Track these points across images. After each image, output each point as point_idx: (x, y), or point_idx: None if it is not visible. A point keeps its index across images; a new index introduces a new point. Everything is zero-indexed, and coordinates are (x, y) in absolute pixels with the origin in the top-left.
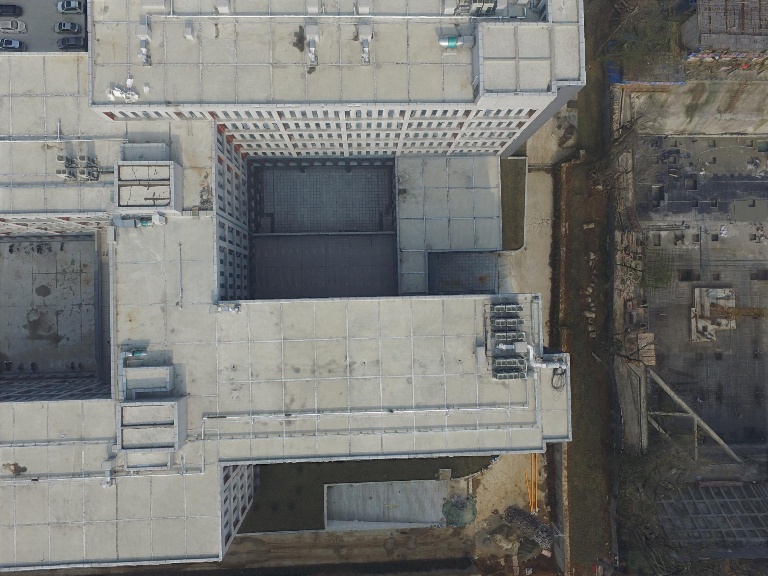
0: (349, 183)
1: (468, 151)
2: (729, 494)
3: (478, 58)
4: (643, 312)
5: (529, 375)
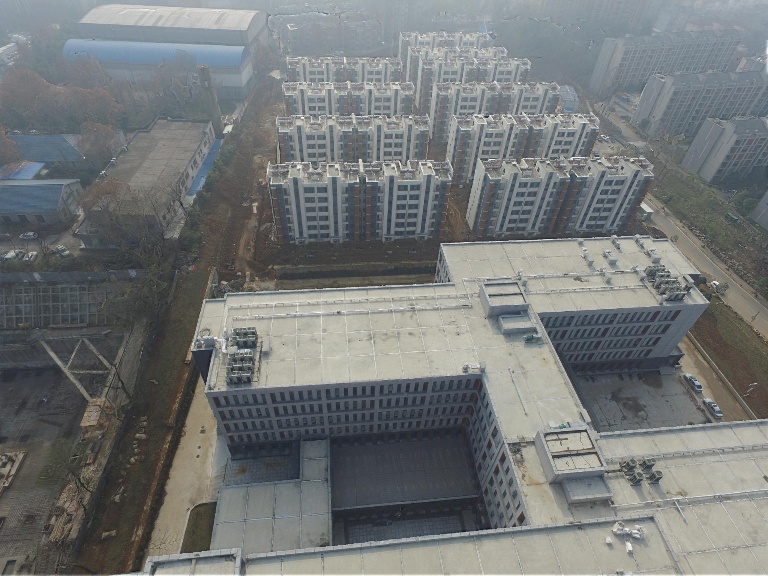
0: None
1: None
2: (65, 319)
3: None
4: None
5: None
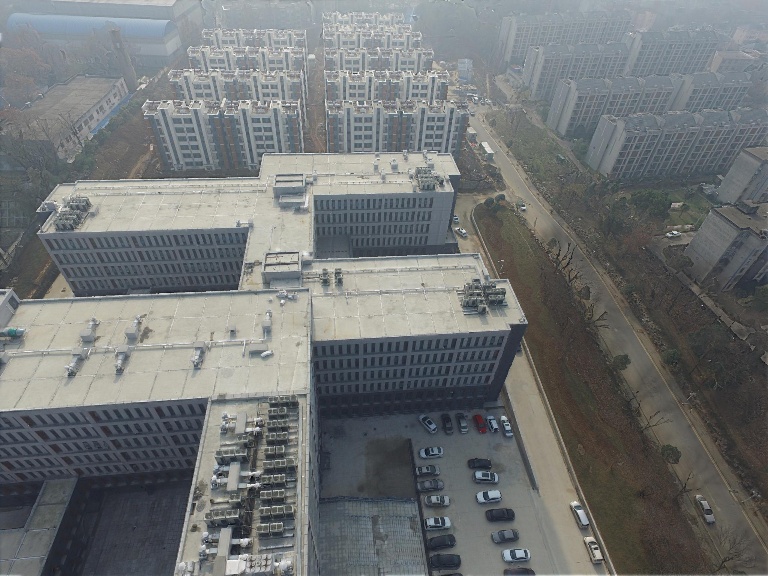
0: None
1: None
2: None
3: None
4: None
5: None
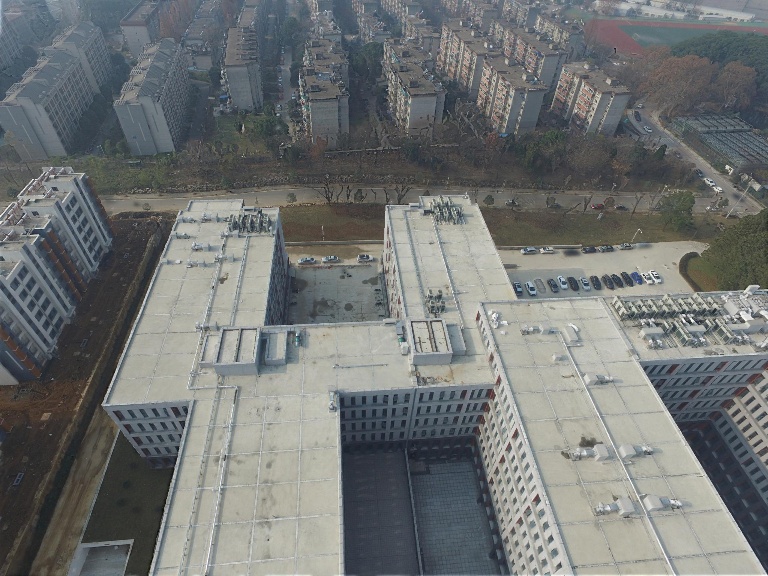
0: (477, 557)
1: None
2: None
3: None
4: None
5: None
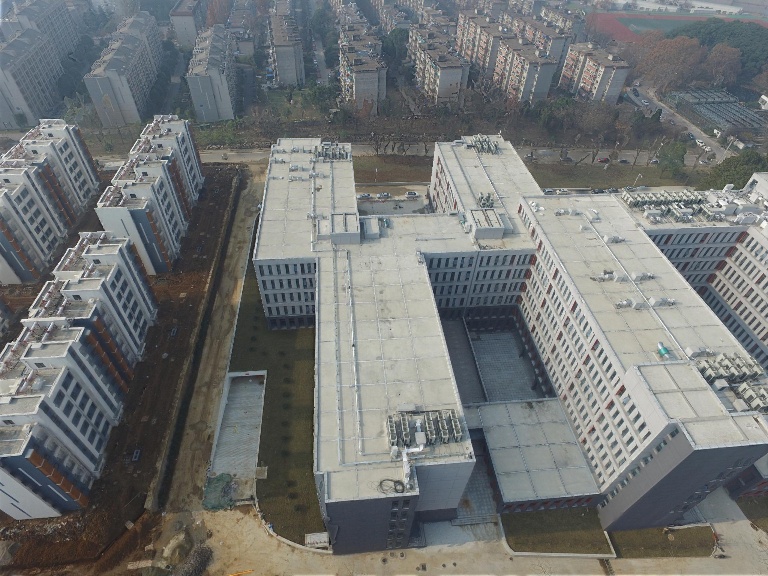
0: (523, 390)
1: (591, 458)
2: None
3: None
4: None
5: None
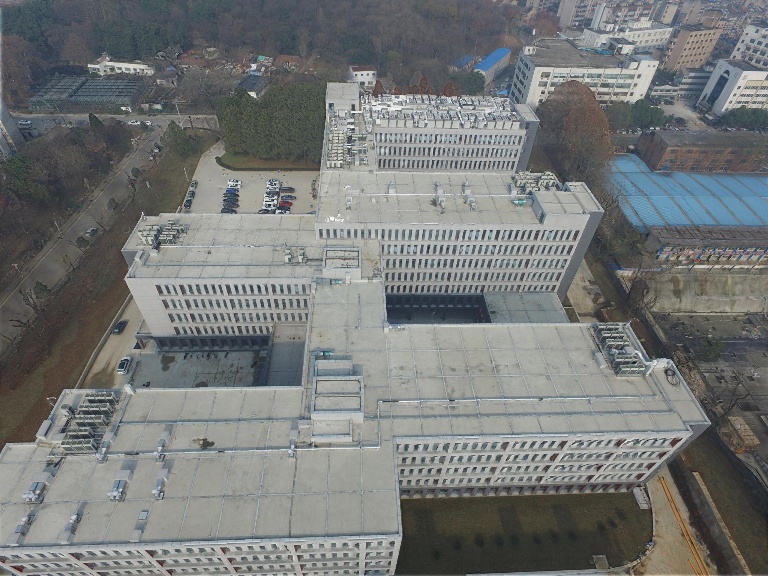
0: None
1: (534, 290)
2: None
3: (538, 203)
4: (722, 411)
5: (646, 371)
